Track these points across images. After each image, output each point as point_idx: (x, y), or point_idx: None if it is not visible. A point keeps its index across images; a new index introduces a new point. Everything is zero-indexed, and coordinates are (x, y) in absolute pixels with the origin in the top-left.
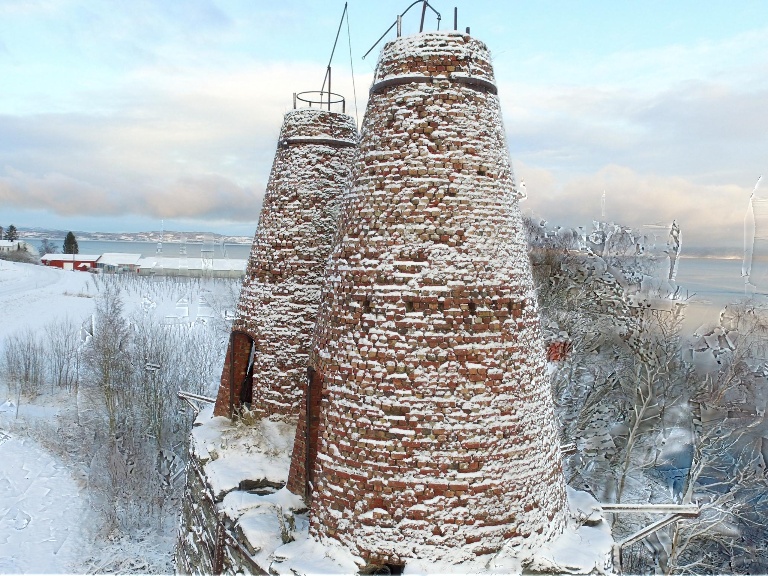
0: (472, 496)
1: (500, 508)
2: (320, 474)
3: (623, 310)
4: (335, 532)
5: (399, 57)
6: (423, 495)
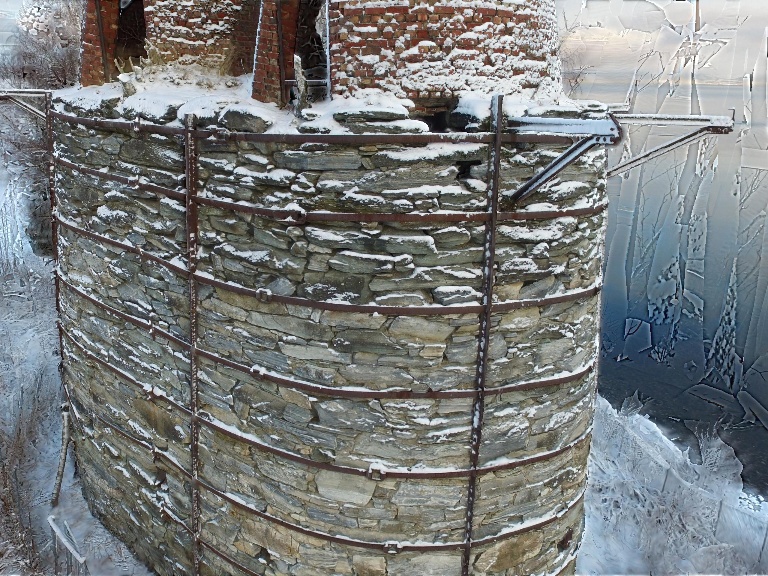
0: (516, 25)
1: (537, 43)
2: (340, 20)
3: None
4: (371, 80)
5: None
6: (471, 22)
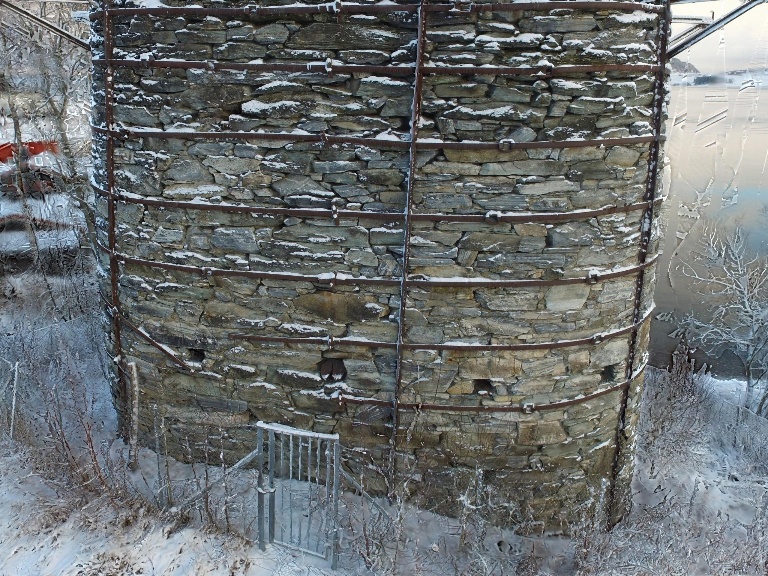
0: None
1: None
2: None
3: None
4: None
5: None
6: None
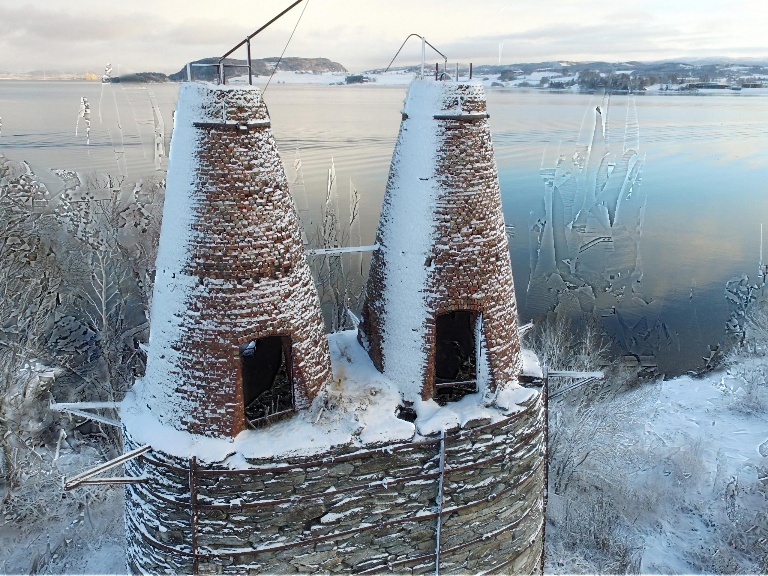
0: None
1: None
2: None
3: (65, 207)
4: None
5: (478, 100)
6: None
